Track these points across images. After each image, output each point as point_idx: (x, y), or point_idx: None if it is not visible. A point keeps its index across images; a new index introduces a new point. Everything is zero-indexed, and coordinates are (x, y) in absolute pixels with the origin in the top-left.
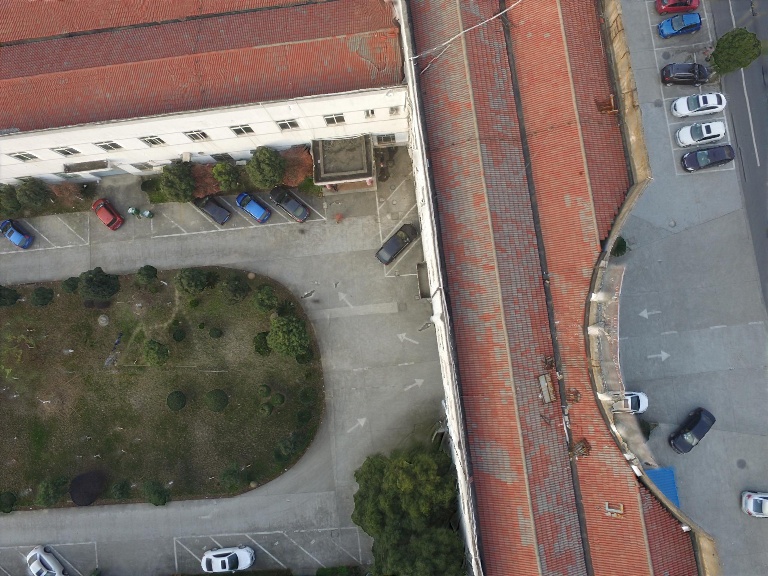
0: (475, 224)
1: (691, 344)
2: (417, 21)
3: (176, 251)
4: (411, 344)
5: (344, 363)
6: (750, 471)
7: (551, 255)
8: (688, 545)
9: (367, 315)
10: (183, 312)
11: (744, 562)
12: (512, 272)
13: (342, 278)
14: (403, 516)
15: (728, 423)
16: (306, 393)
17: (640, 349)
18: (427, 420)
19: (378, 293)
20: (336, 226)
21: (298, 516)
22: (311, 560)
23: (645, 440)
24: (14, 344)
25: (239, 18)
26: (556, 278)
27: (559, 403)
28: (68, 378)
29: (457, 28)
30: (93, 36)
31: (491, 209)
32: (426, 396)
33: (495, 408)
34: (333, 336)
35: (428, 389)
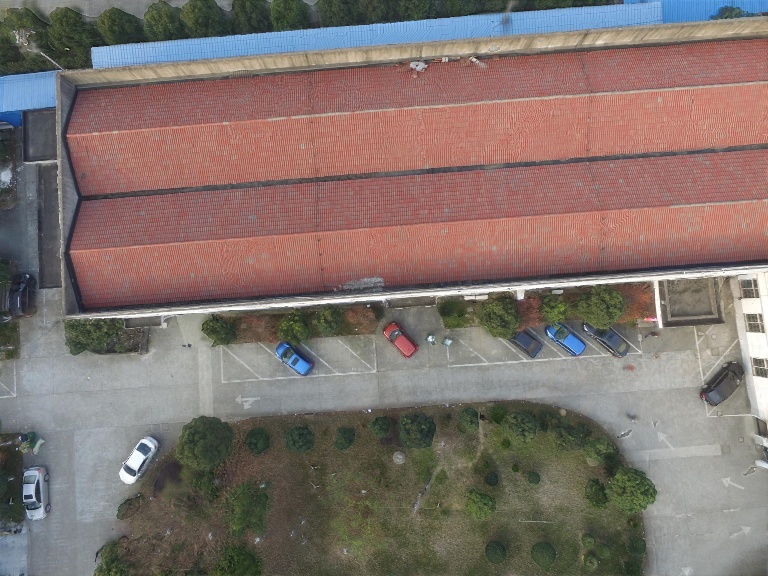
0: None
1: None
2: None
3: (477, 382)
4: (736, 489)
5: (666, 508)
6: None
7: None
8: None
9: (689, 457)
10: (489, 451)
11: None
12: None
13: (661, 417)
14: None
15: None
16: None
17: None
18: (755, 569)
19: (700, 434)
20: (653, 361)
21: None
22: None
23: None
24: (296, 482)
25: (634, 164)
26: None
27: None
28: (362, 522)
29: None
30: (463, 174)
31: None
32: (753, 544)
33: None
34: (653, 479)
35: (755, 537)
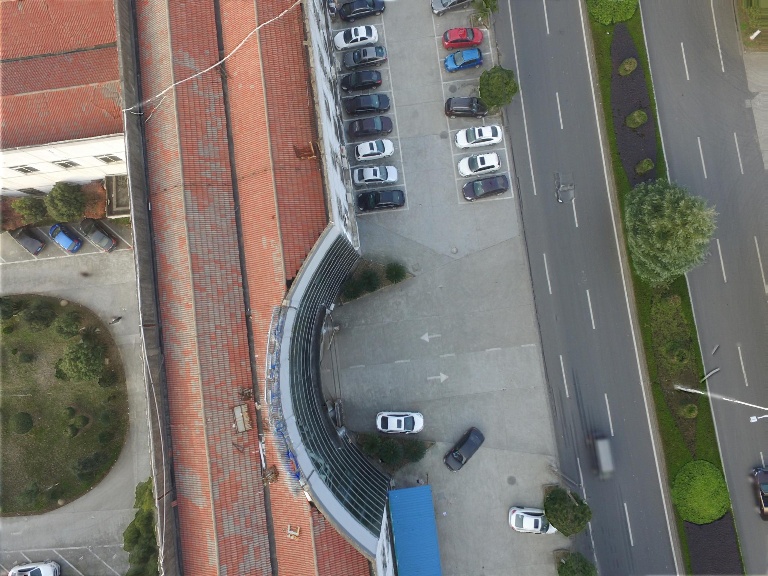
0: (180, 265)
1: (468, 366)
2: (143, 73)
3: None
4: None
5: None
6: (519, 487)
7: (253, 293)
8: (363, 564)
9: None
10: None
11: (511, 574)
12: (211, 310)
13: None
14: (153, 535)
15: (500, 441)
16: (108, 415)
17: (421, 371)
18: None
19: None
20: None
21: (102, 532)
22: (113, 574)
23: (417, 459)
24: None
25: (12, 66)
26: (256, 315)
27: (255, 432)
28: None
29: (170, 81)
30: None
31: (192, 251)
32: None
33: (191, 437)
34: (138, 360)
35: None
